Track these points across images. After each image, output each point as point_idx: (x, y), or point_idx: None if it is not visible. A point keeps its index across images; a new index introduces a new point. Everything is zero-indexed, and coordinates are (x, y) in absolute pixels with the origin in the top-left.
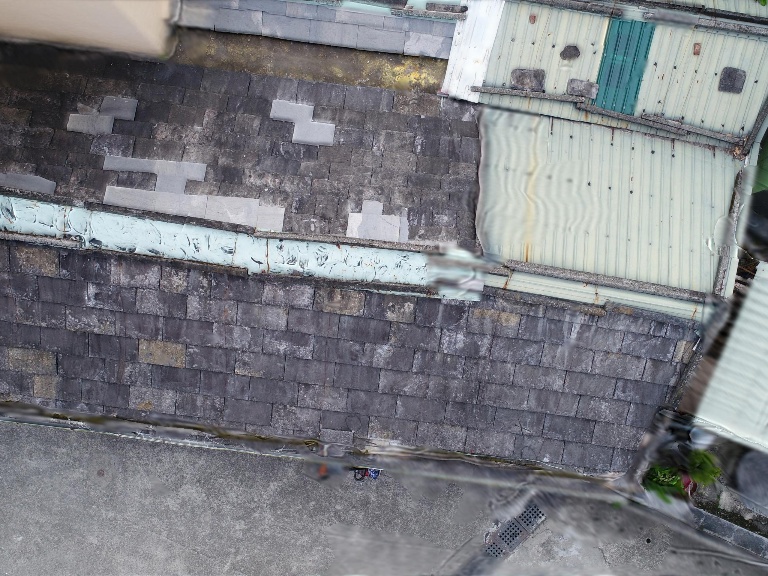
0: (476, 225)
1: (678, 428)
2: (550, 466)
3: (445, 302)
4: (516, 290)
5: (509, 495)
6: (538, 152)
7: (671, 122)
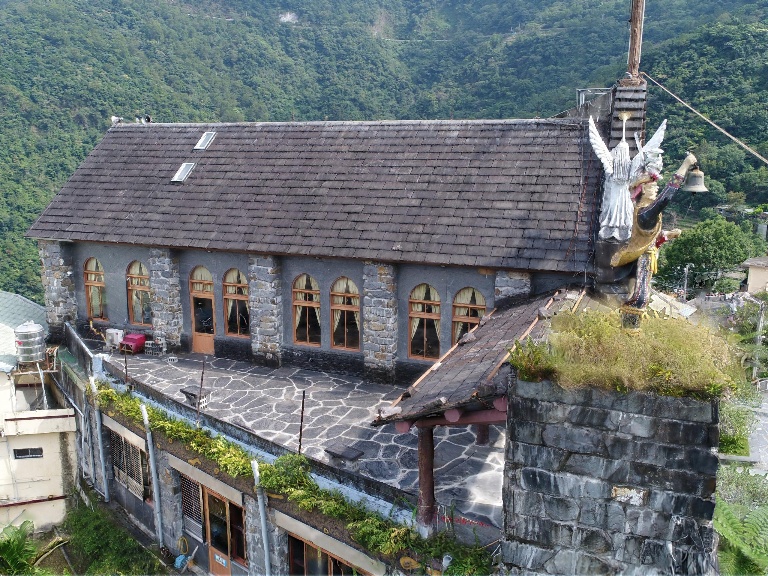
0: None
1: None
2: None
3: None
4: None
5: None
6: None
7: None
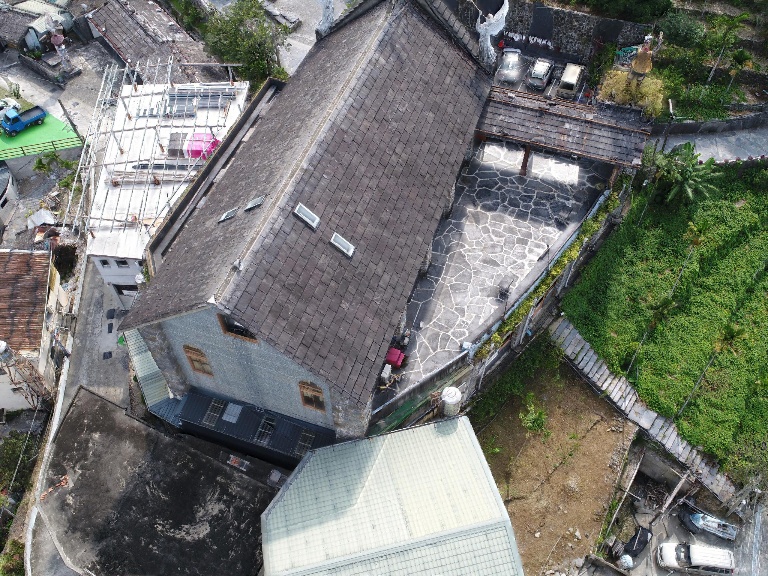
0: (16, 6)
1: (39, 49)
2: (7, 40)
3: (3, 11)
4: (14, 10)
5: (7, 66)
6: (35, 4)
7: (59, 5)
